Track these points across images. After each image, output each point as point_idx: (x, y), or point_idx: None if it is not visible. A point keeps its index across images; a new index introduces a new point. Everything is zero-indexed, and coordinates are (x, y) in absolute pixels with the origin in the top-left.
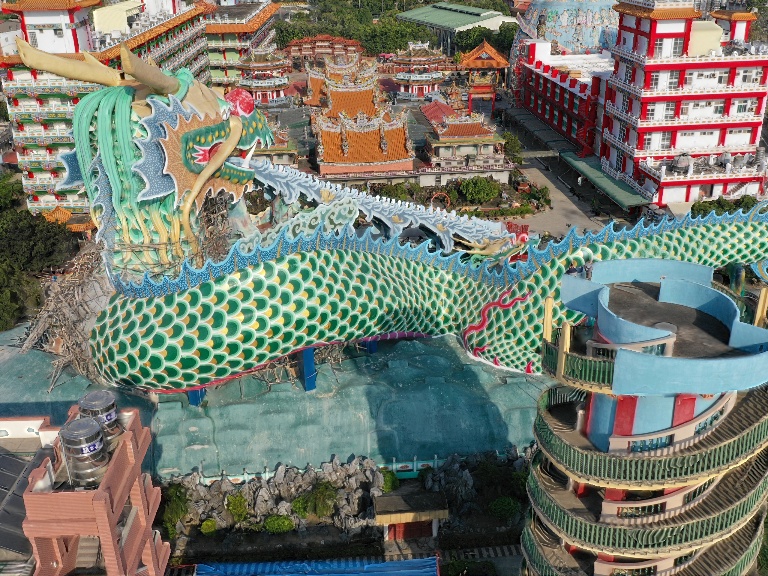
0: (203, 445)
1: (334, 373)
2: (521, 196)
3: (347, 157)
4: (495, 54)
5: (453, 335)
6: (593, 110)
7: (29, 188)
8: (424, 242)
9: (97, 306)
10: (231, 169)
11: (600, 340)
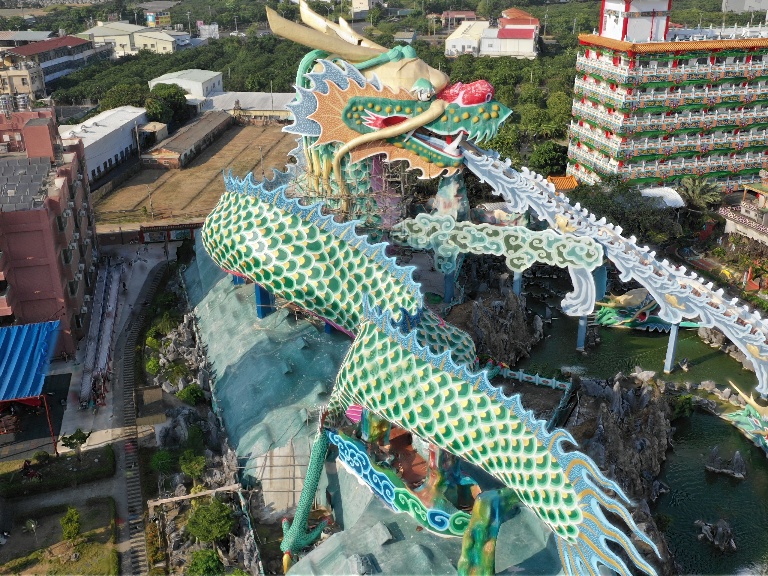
0: (208, 306)
1: (283, 320)
2: None
3: None
4: None
5: None
6: None
7: None
8: None
9: None
10: (420, 146)
11: None
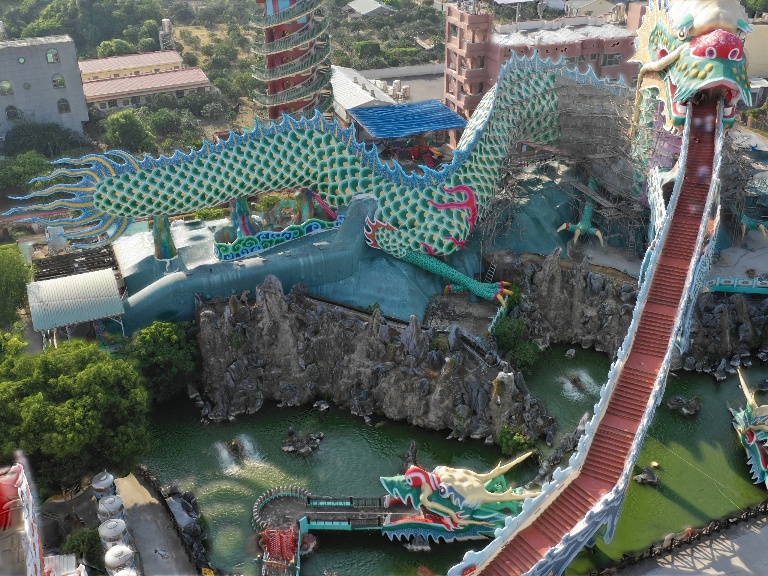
0: None
1: None
2: None
3: None
4: None
5: None
6: None
7: None
8: None
9: None
10: None
11: None
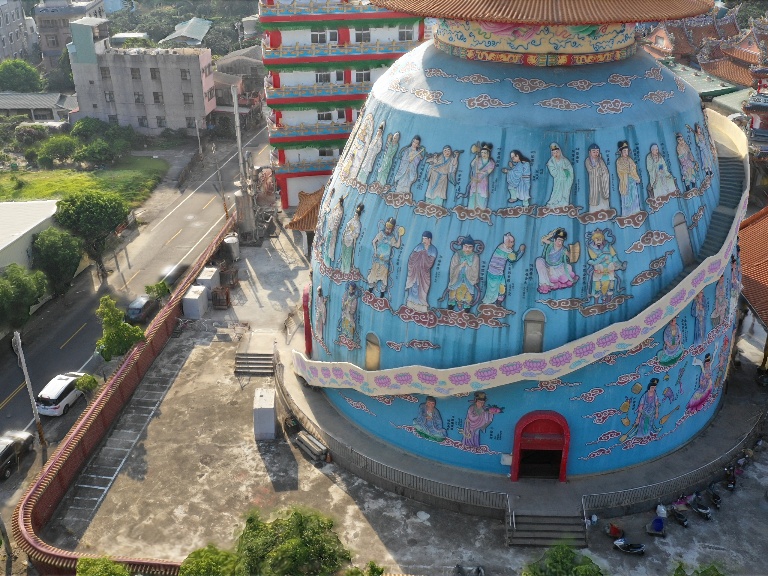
0: None
1: None
2: None
3: None
4: None
5: None
6: None
7: None
8: None
9: None
10: None
11: None
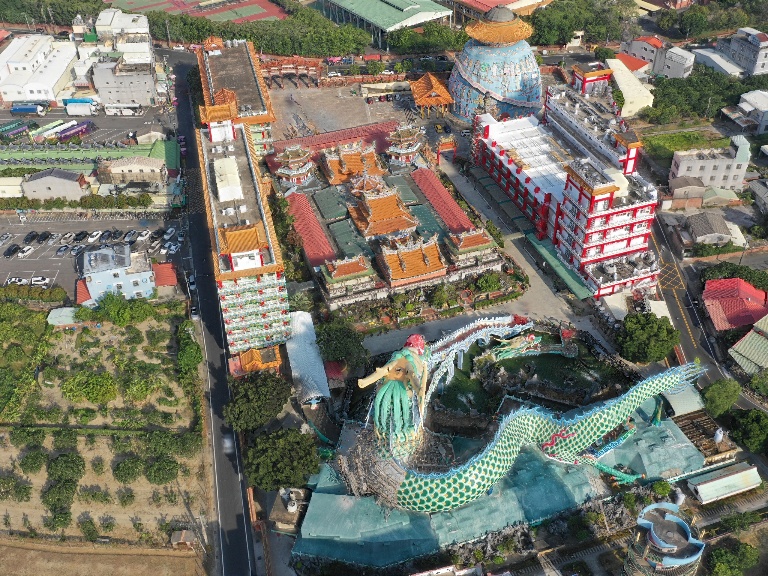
0: (456, 531)
1: None
2: (511, 279)
3: (406, 273)
4: (439, 87)
5: (535, 443)
6: (546, 210)
7: (231, 340)
8: (521, 407)
9: (397, 479)
10: None
11: (654, 543)
